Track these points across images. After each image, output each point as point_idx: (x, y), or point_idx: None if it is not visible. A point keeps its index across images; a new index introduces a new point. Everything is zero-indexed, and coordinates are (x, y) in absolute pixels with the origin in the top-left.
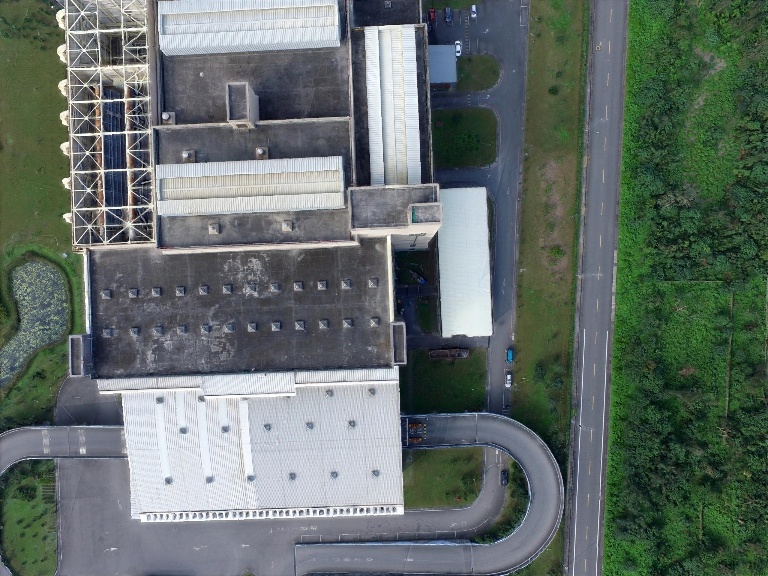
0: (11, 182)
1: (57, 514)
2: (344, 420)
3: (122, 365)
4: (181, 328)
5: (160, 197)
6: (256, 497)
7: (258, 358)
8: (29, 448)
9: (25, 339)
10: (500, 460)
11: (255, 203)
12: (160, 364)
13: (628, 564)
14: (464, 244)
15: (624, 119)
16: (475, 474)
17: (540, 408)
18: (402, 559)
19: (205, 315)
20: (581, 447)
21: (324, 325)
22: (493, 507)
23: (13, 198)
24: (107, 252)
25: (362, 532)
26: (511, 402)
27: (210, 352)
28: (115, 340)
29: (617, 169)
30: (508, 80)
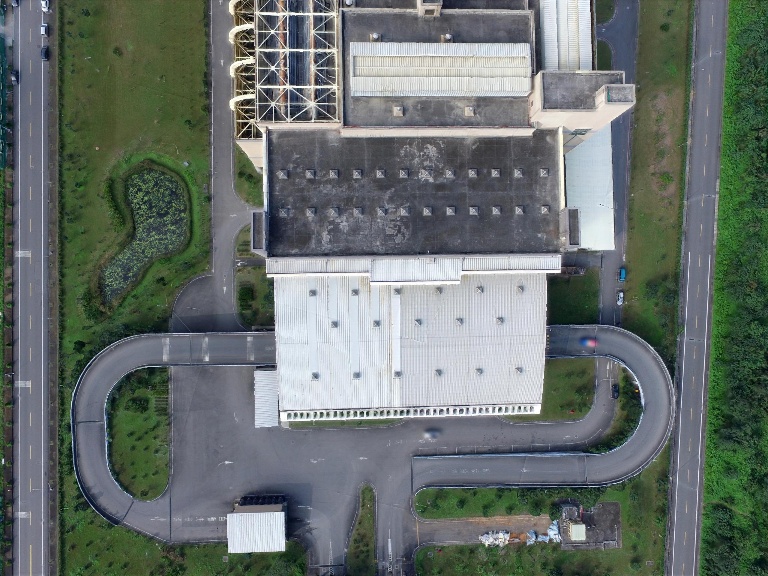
0: (131, 89)
1: (169, 427)
2: (492, 316)
3: (297, 245)
4: (359, 209)
5: (353, 74)
6: (400, 394)
7: (432, 241)
8: (147, 356)
9: (140, 248)
10: (611, 375)
11: (447, 84)
12: (335, 245)
13: (731, 472)
14: (590, 162)
15: (727, 58)
16: (587, 388)
17: (649, 325)
18: (518, 470)
19: (381, 198)
20: (685, 363)
21: (498, 210)
22: (604, 420)
23: (132, 105)
24: (285, 133)
25: (479, 444)
26: (622, 319)
27: (385, 234)
28: (290, 220)
29: (720, 104)
30: (622, 16)
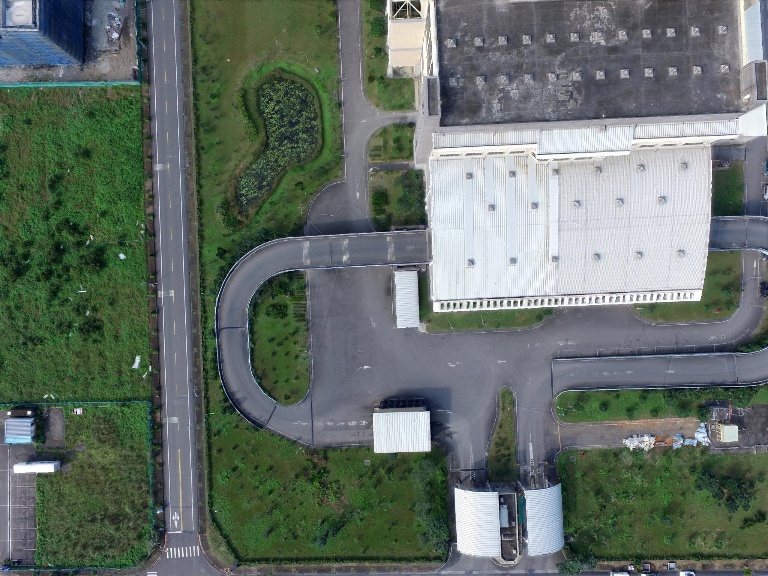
0: None
1: (308, 333)
2: (654, 196)
3: (467, 114)
4: (530, 74)
5: None
6: (556, 281)
7: (606, 106)
8: (287, 260)
9: (273, 157)
10: (758, 273)
11: None
12: (506, 113)
13: None
14: None
15: None
16: None
17: None
18: (663, 371)
19: (551, 64)
20: None
21: (676, 70)
22: (752, 320)
23: (261, 15)
24: (451, 1)
25: (620, 346)
26: None
27: (557, 101)
28: (460, 89)
29: None
30: None
